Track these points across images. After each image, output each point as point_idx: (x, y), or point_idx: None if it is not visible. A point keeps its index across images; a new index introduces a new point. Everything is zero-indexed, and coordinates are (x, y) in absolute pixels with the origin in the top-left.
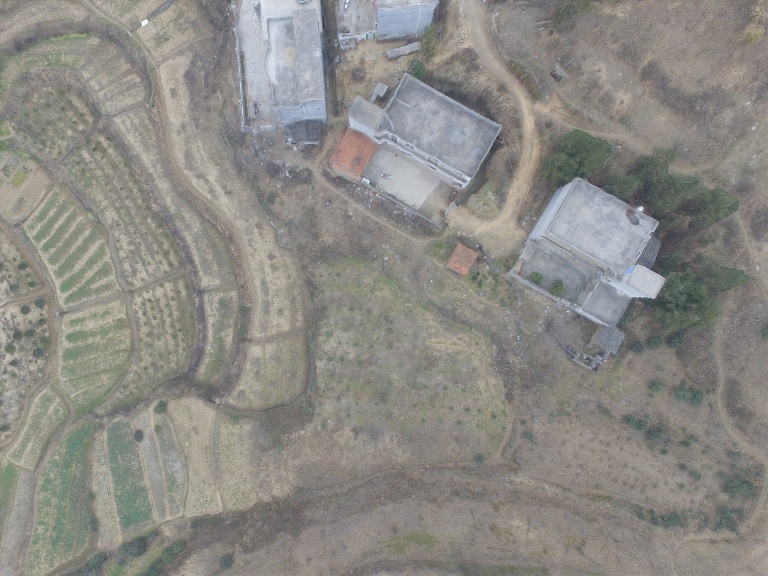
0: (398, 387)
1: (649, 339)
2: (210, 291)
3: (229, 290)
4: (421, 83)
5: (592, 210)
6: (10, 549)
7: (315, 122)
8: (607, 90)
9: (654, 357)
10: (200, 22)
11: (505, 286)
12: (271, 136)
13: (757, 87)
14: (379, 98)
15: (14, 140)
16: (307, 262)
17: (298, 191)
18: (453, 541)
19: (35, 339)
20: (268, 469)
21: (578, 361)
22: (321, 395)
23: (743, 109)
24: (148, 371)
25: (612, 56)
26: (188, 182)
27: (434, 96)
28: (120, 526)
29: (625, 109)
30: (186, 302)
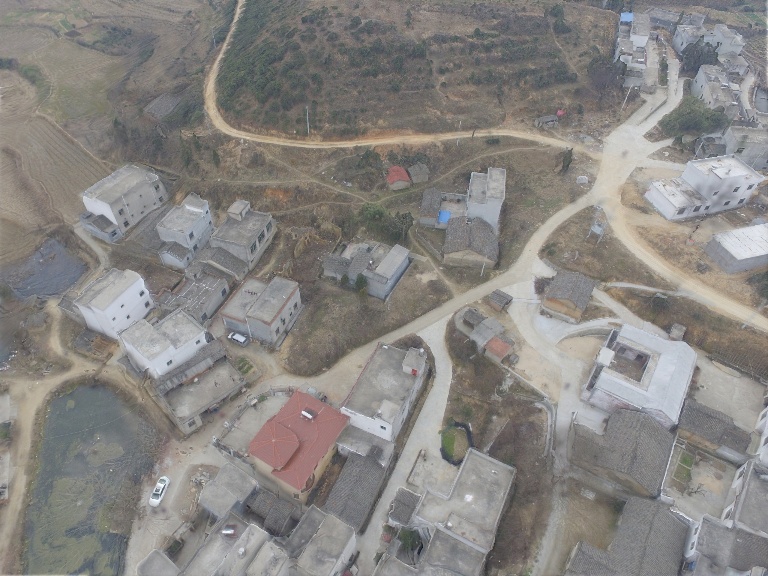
0: None
1: None
2: None
3: None
4: None
5: None
6: None
7: None
8: None
9: None
10: None
11: None
12: None
13: None
14: None
15: None
16: None
17: None
18: None
19: None
20: (702, 9)
21: None
22: None
23: None
24: None
25: None
26: (760, 62)
27: None
28: None
29: None
30: None
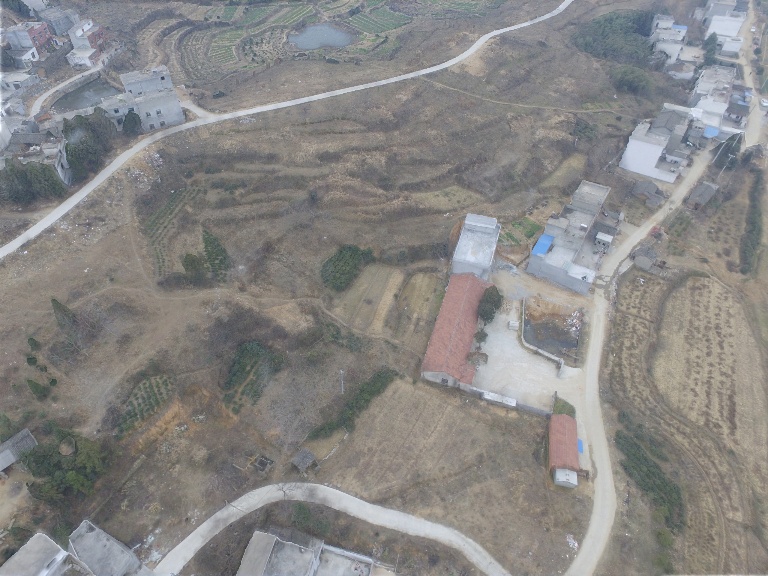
0: None
1: None
2: None
3: (166, 39)
4: None
5: None
6: None
7: None
8: None
9: None
10: None
11: None
12: None
13: None
14: None
15: None
16: None
17: None
18: None
19: None
20: None
21: None
22: None
23: None
24: None
25: None
26: None
27: None
28: (238, 8)
29: None
30: None
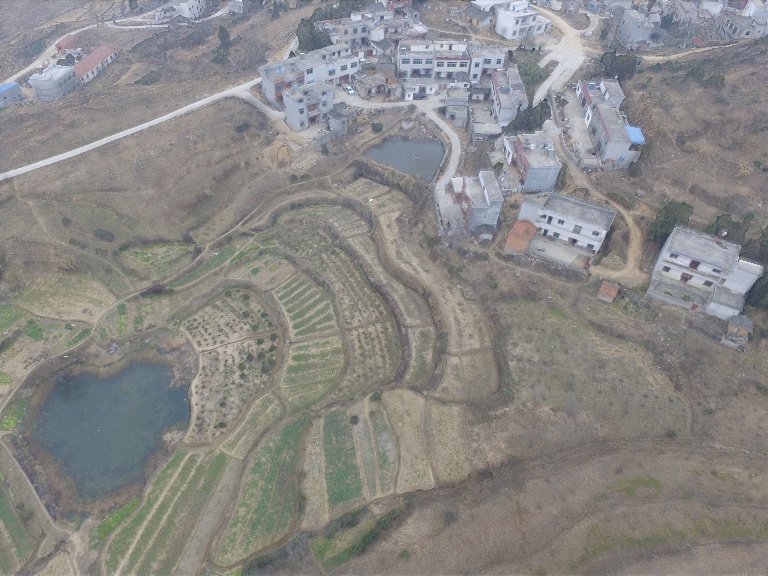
0: (581, 380)
1: None
2: (412, 327)
3: (427, 326)
4: (561, 196)
5: (693, 242)
6: (201, 537)
7: (490, 226)
8: (673, 199)
9: None
10: (405, 200)
11: (645, 309)
12: (459, 237)
13: (760, 199)
14: None
15: (277, 248)
16: (489, 303)
17: (479, 264)
18: (682, 485)
19: (264, 361)
20: (480, 439)
21: (726, 340)
22: (517, 384)
23: (758, 207)
24: (360, 379)
25: (669, 185)
26: (398, 265)
27: (570, 202)
28: (328, 504)
29: None
30: (392, 335)
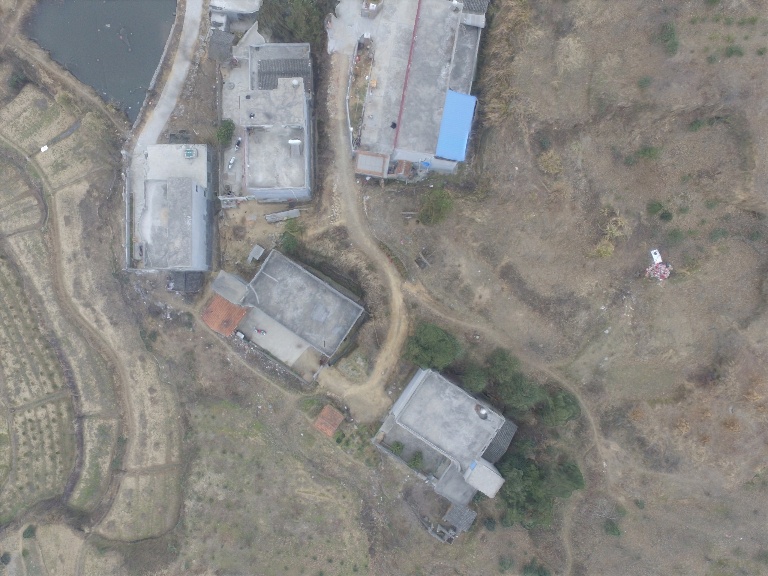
0: (264, 533)
1: (502, 517)
2: (91, 417)
3: (109, 417)
4: (288, 259)
5: (442, 402)
6: None
7: (195, 273)
8: (466, 284)
9: (507, 534)
10: (99, 153)
11: (372, 447)
12: (155, 278)
13: (611, 294)
14: (255, 260)
15: None
16: (185, 401)
17: (179, 333)
18: None
19: None
20: None
21: (431, 534)
22: (187, 535)
23: (597, 313)
24: (24, 490)
25: (472, 253)
26: (75, 310)
27: (300, 272)
28: None
29: (483, 303)
30: (67, 424)
